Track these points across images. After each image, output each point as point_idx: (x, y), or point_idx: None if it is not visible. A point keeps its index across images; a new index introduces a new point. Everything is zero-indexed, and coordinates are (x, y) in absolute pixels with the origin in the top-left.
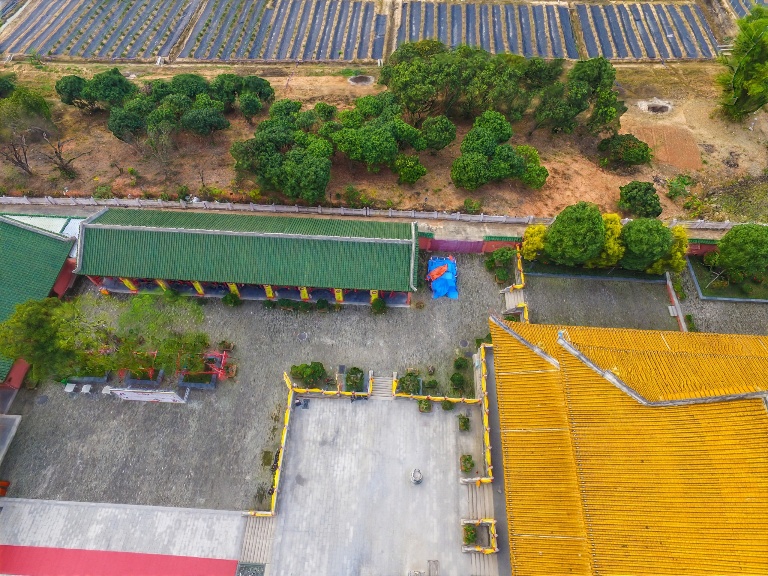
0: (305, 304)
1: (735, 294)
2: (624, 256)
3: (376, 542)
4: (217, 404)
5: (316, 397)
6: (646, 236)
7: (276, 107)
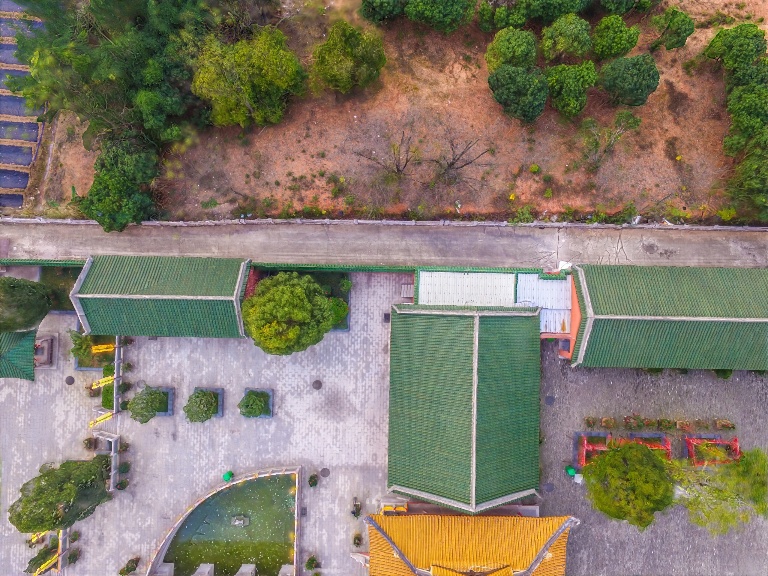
0: None
1: None
2: None
3: None
4: (724, 485)
5: None
6: None
7: (742, 50)
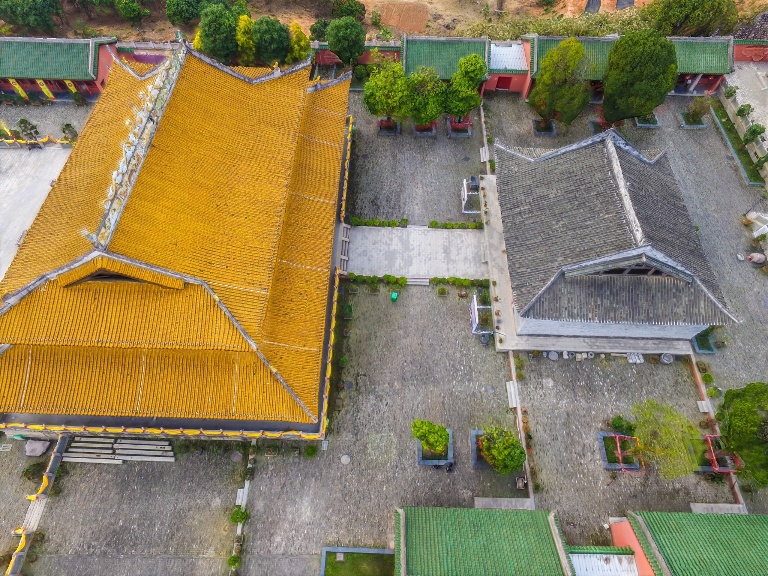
0: (19, 97)
1: (359, 86)
2: (259, 51)
3: (13, 222)
4: None
5: (3, 148)
6: (258, 26)
7: None
